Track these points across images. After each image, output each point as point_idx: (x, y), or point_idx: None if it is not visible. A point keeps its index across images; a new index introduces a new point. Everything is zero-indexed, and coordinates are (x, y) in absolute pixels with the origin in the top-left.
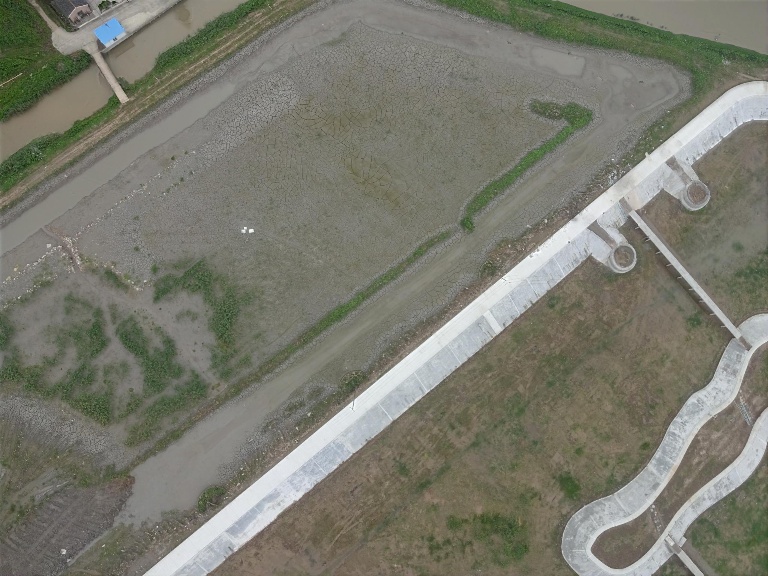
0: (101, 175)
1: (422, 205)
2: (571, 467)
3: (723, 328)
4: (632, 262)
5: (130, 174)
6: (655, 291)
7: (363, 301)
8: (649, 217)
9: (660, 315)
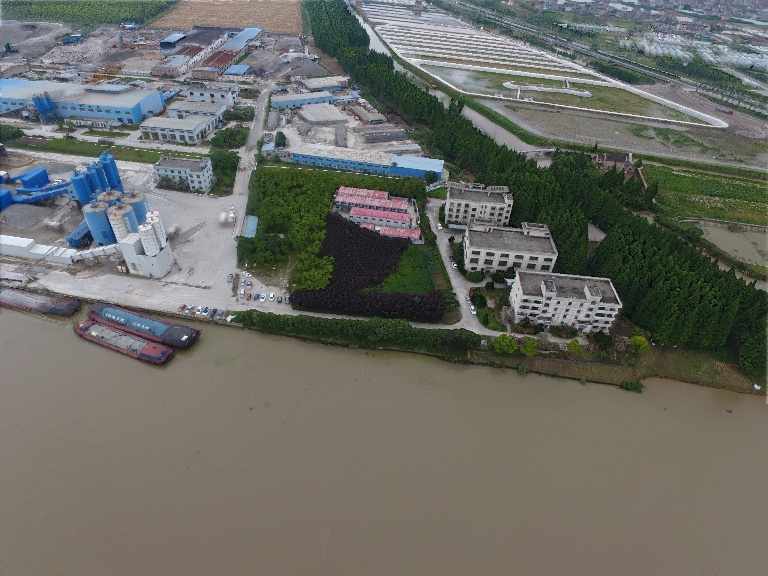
0: None
1: None
2: None
3: None
4: None
5: None
6: None
7: None
8: None
9: None
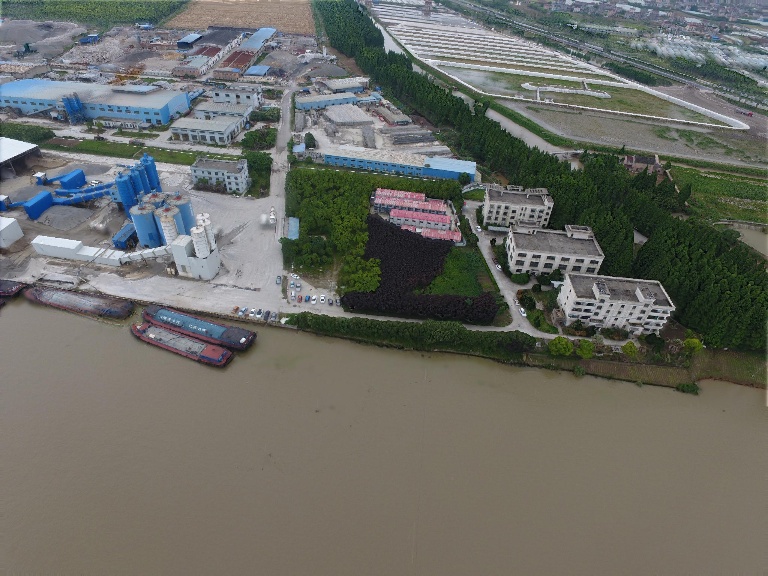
0: None
1: None
2: None
3: None
4: None
5: None
6: None
7: None
8: None
9: None
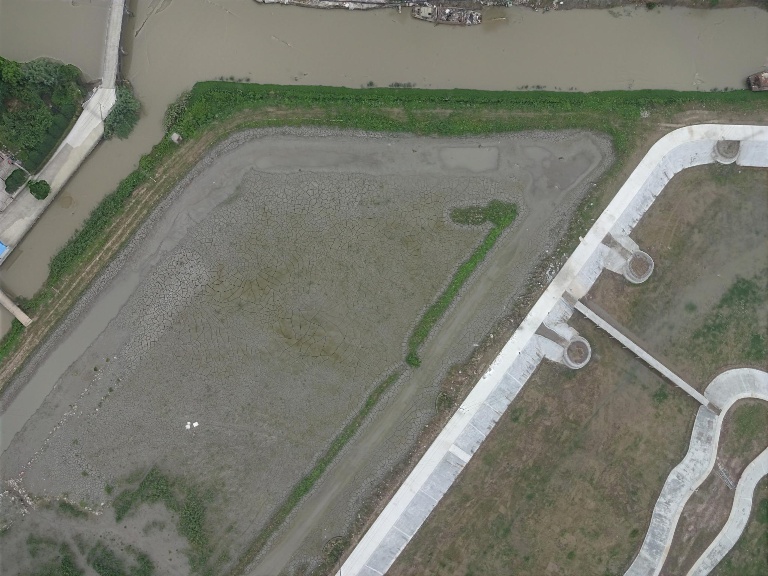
0: (27, 406)
1: (363, 351)
2: (566, 572)
3: (690, 397)
4: (587, 356)
5: (56, 397)
6: (616, 376)
7: (326, 466)
8: (596, 301)
9: (625, 399)
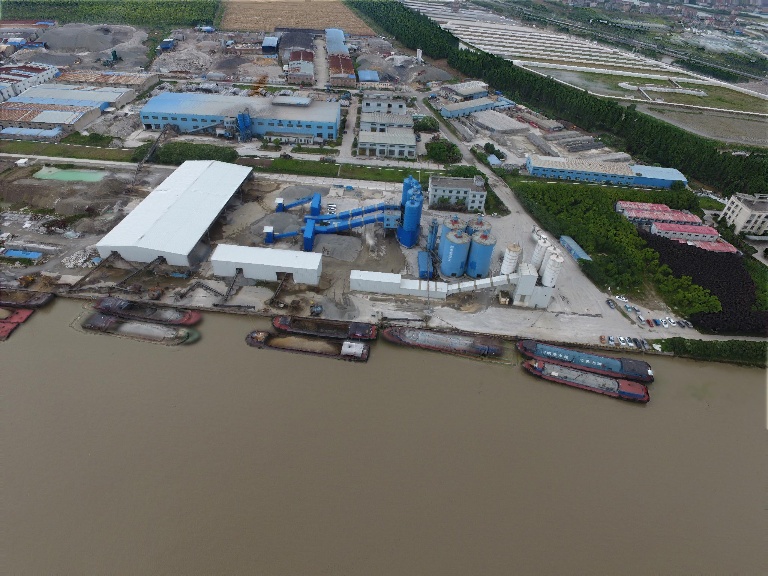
0: None
1: None
2: None
3: None
4: None
5: None
6: None
7: None
8: None
9: None
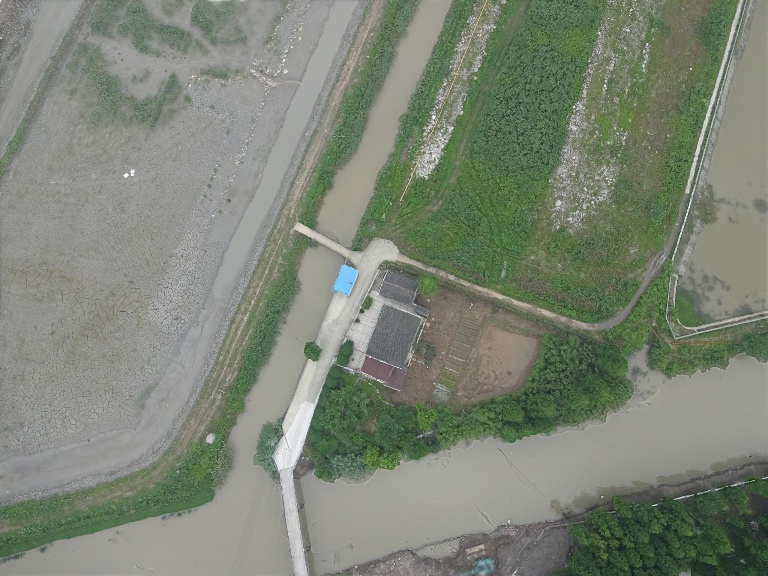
0: (281, 153)
1: None
2: None
3: None
4: None
5: (257, 167)
6: None
7: None
8: None
9: None
